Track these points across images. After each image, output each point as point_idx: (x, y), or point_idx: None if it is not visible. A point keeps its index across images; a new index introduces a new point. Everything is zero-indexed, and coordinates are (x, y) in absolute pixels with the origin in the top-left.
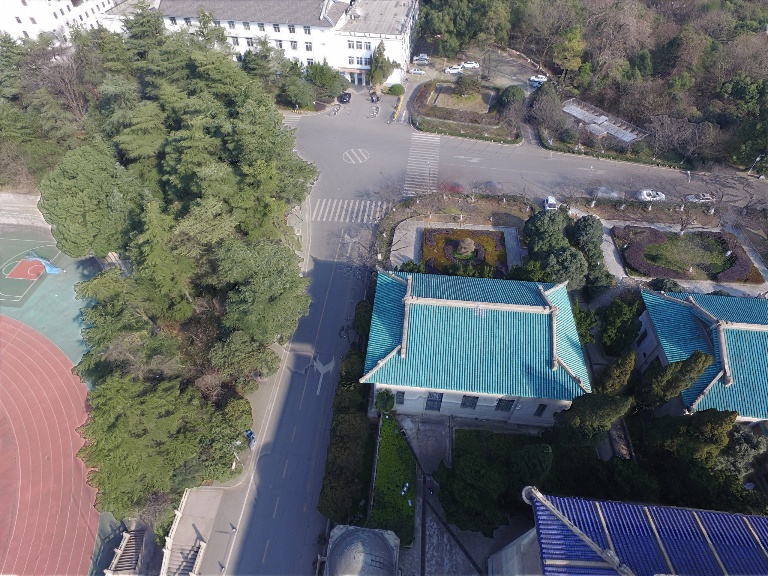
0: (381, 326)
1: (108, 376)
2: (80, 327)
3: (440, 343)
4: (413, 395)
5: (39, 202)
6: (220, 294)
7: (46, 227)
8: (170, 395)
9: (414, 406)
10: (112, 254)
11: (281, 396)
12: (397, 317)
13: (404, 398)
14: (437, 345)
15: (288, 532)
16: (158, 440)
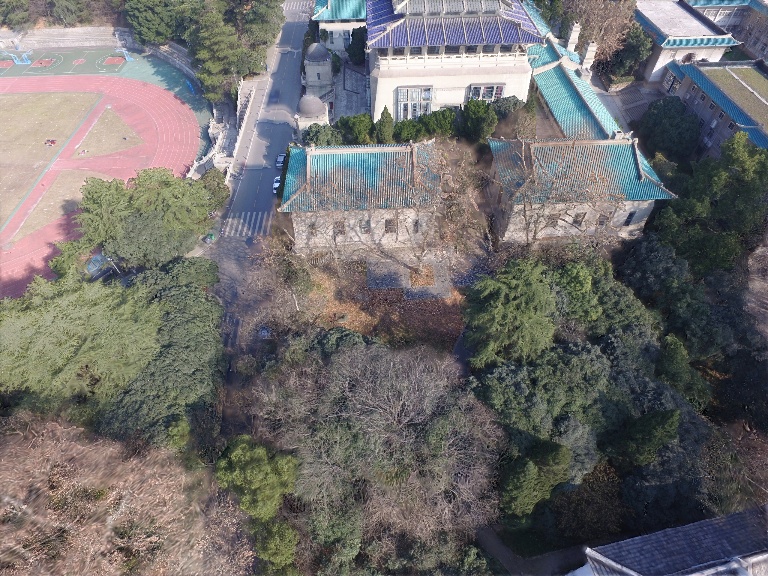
0: (319, 6)
1: (207, 13)
2: (157, 76)
3: (344, 3)
4: (336, 34)
5: (126, 4)
6: (240, 20)
7: (115, 45)
8: (232, 29)
9: (338, 44)
10: (164, 47)
11: (277, 59)
12: (326, 1)
13: (333, 38)
14: (343, 4)
15: (289, 87)
16: (230, 42)
